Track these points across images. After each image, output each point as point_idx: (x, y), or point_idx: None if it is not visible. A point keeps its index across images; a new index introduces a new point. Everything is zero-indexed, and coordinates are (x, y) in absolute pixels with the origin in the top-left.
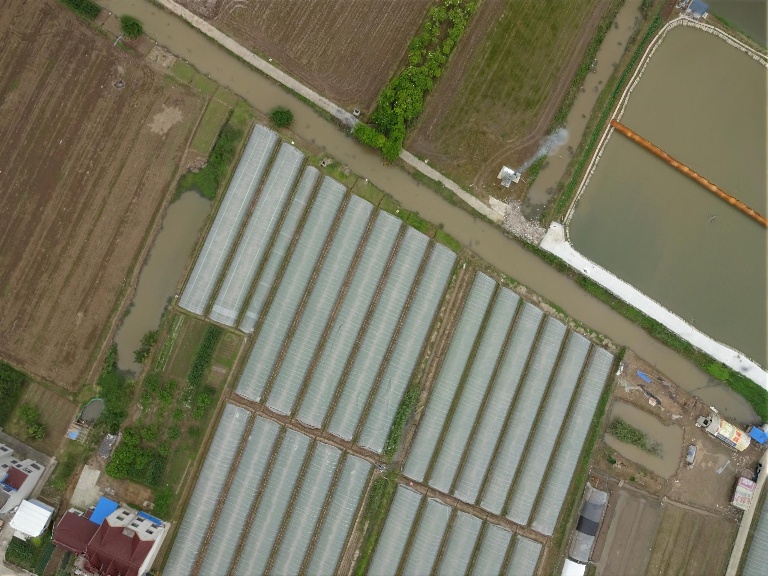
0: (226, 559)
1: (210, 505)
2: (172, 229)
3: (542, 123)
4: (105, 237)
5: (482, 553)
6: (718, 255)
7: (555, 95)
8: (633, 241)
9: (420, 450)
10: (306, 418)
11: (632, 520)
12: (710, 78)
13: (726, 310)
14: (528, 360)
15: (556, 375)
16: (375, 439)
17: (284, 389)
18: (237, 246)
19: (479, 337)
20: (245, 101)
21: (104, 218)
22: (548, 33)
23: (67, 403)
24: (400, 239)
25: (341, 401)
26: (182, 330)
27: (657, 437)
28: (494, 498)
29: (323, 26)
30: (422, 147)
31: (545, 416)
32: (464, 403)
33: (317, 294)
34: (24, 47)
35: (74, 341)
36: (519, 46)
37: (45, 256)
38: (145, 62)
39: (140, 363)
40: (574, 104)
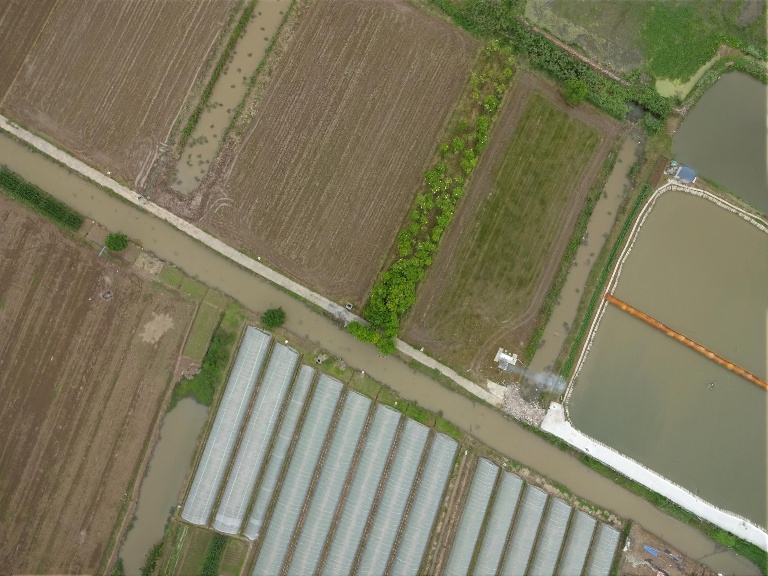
0: None
1: None
2: (170, 439)
3: (536, 301)
4: (103, 453)
5: None
6: (718, 422)
7: (547, 271)
8: (633, 415)
9: None
10: None
11: None
12: (702, 242)
13: (729, 477)
14: (535, 543)
15: (563, 556)
16: None
17: None
18: (237, 451)
19: (484, 524)
20: (236, 301)
21: (101, 433)
22: (537, 208)
23: None
24: (400, 431)
25: None
26: (186, 541)
27: None
28: None
29: (310, 219)
30: (417, 335)
31: None
32: None
33: (320, 493)
34: (8, 265)
35: (78, 561)
36: (509, 224)
37: (44, 477)
38: (132, 270)
39: None
40: (567, 279)
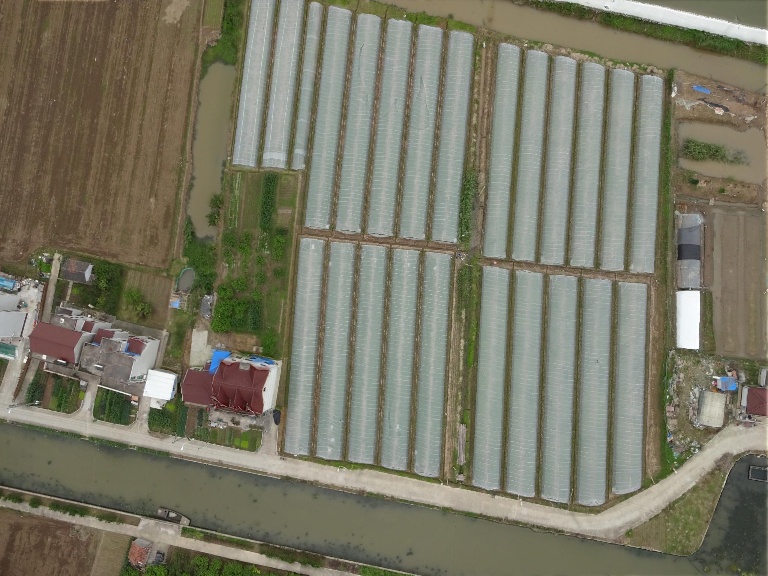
0: (341, 379)
1: (312, 333)
2: (208, 101)
3: None
4: (154, 127)
5: (586, 308)
6: None
7: None
8: None
9: (494, 228)
10: (376, 229)
11: (736, 235)
12: None
13: None
14: (575, 112)
15: (608, 117)
16: (447, 230)
17: (348, 209)
18: (269, 97)
19: (519, 105)
20: None
21: (149, 111)
22: None
23: (163, 280)
24: (415, 41)
25: (404, 205)
26: (242, 186)
27: (736, 146)
28: (582, 251)
29: None
30: None
31: (609, 158)
32: (523, 170)
33: (353, 115)
34: None
35: (153, 224)
36: None
37: (109, 159)
38: None
39: (214, 226)
40: None
